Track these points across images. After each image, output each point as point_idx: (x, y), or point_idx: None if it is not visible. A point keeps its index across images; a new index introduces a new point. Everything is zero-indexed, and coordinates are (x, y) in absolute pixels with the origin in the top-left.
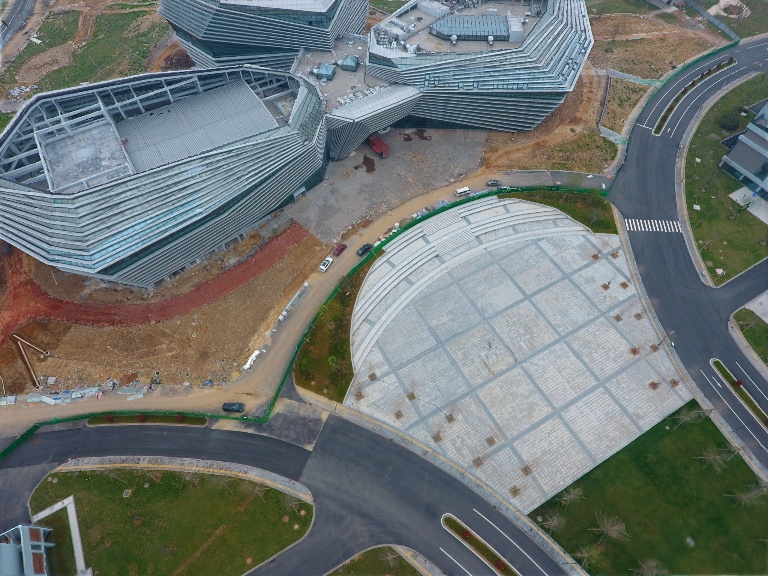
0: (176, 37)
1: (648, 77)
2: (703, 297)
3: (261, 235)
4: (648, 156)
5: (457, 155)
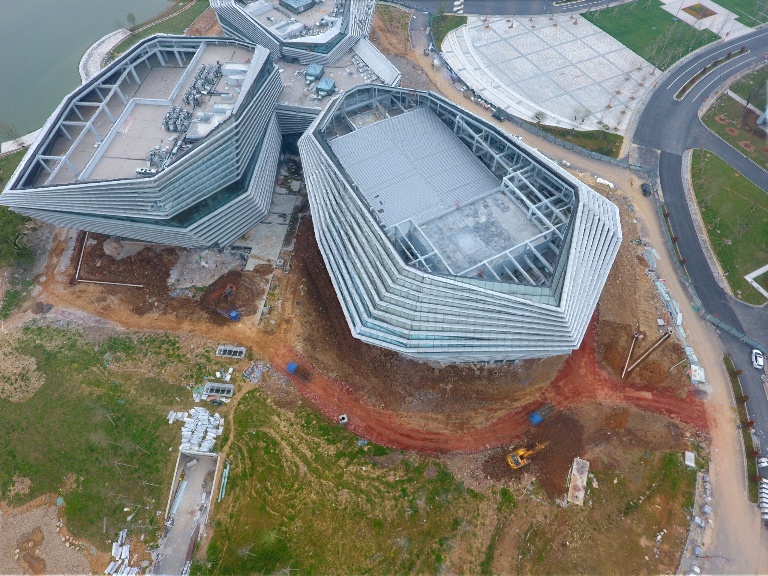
0: (189, 229)
1: None
2: None
3: None
4: None
5: None
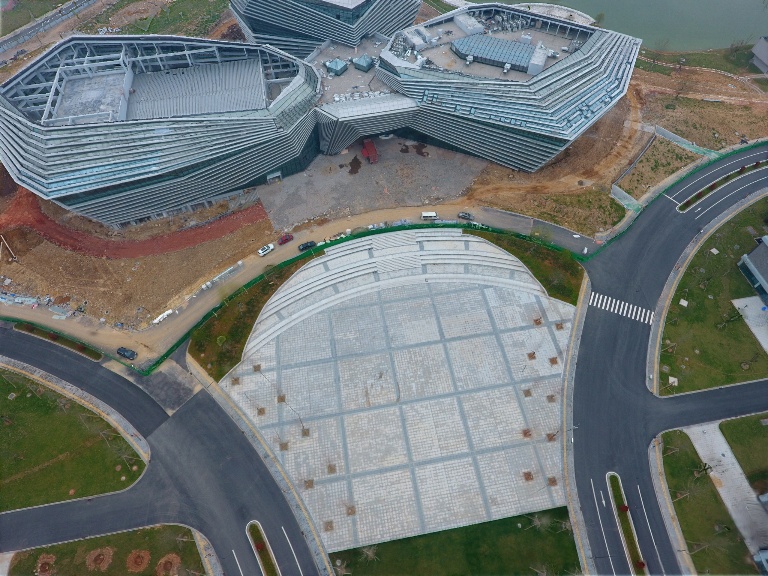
0: None
1: (705, 146)
2: (638, 402)
3: (229, 206)
4: (657, 232)
5: (445, 178)
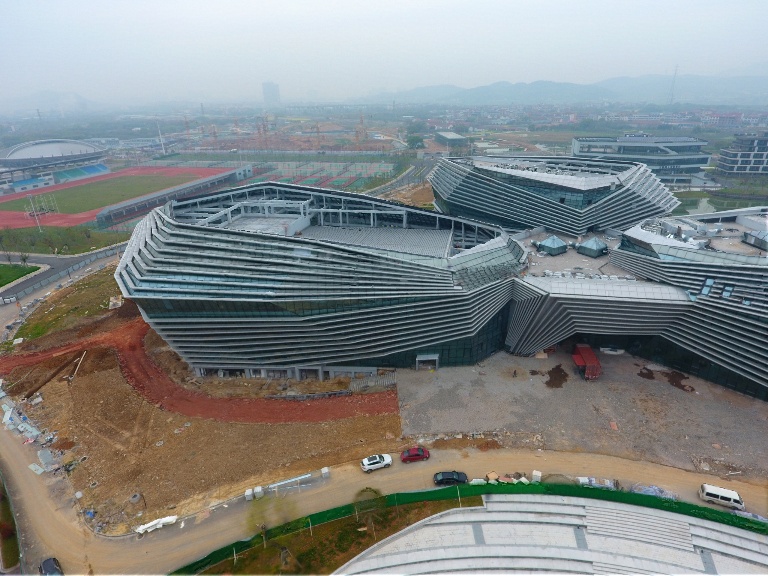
0: None
1: None
2: None
3: (349, 386)
4: None
5: (738, 434)
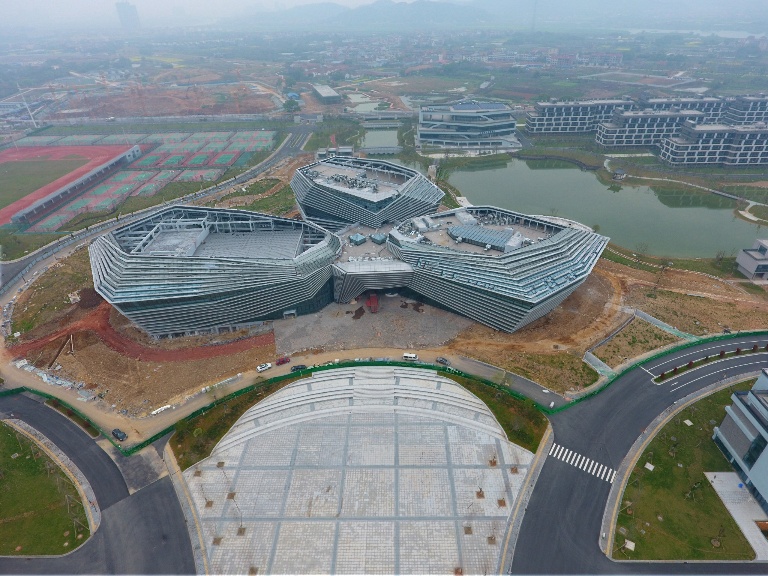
0: None
1: (687, 331)
2: (587, 561)
3: (248, 333)
4: (629, 398)
5: (432, 330)
